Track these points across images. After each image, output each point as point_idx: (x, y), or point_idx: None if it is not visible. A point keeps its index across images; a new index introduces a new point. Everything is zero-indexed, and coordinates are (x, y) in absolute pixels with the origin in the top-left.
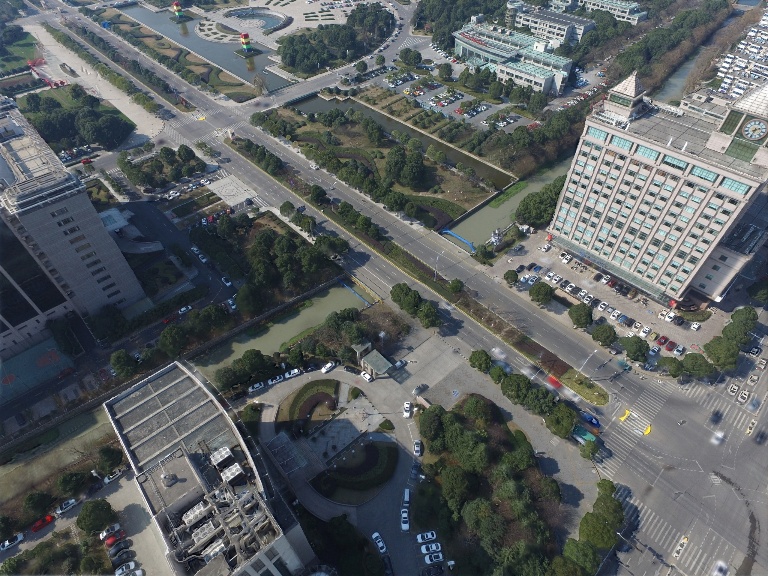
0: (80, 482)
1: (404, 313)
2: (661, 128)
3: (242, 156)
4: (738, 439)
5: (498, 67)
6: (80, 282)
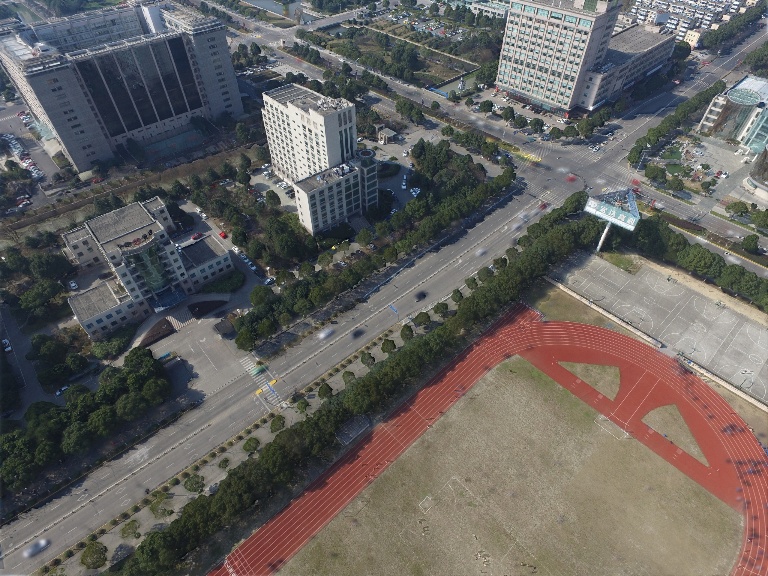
0: (232, 169)
1: (404, 121)
2: (552, 1)
3: (291, 55)
4: (588, 163)
5: (472, 5)
6: (214, 91)
